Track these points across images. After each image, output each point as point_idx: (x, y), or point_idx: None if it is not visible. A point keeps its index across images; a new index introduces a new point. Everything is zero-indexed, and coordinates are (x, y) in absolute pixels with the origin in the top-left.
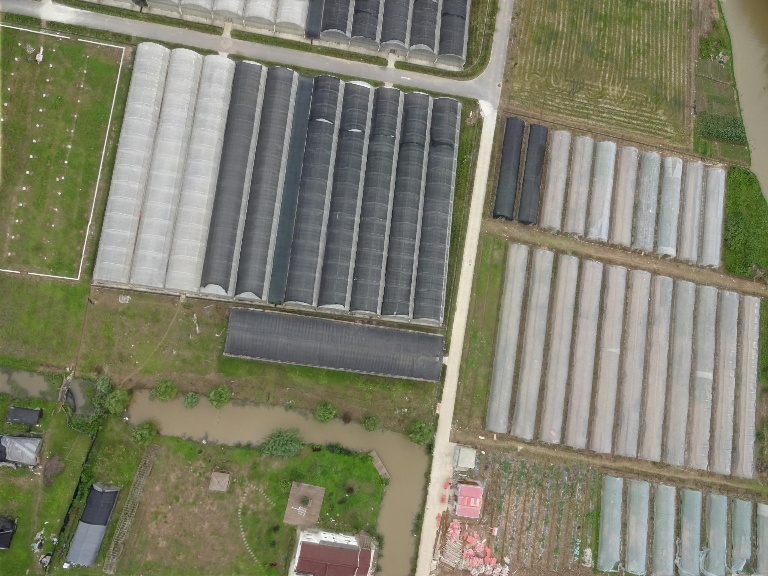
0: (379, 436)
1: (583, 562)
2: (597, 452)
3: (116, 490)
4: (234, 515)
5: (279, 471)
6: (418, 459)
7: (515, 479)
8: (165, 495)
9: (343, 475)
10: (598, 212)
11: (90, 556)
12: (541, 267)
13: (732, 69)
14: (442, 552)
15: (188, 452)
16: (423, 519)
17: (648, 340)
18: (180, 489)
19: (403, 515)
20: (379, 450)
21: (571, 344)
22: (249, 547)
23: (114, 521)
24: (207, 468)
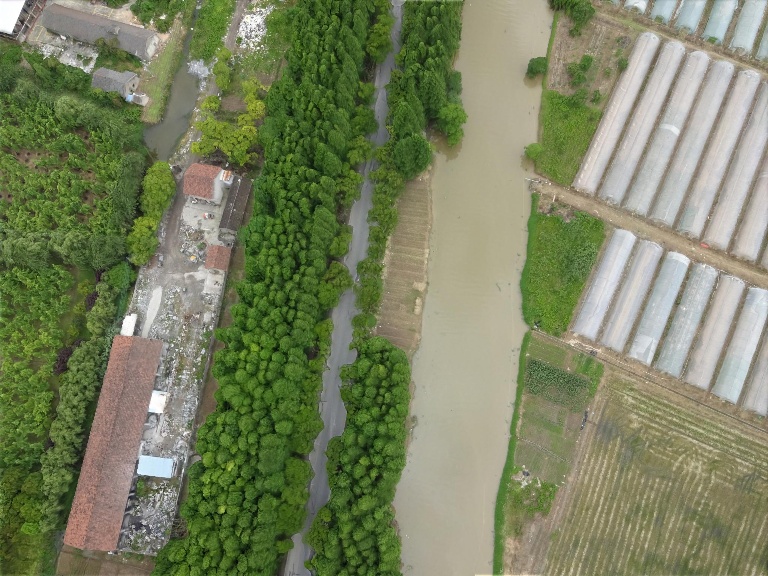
0: None
1: None
2: None
3: None
4: None
5: None
6: None
7: None
8: None
9: None
10: (762, 320)
11: None
12: None
13: (512, 461)
14: None
15: None
16: None
17: (722, 179)
18: None
19: None
20: None
21: None
22: None
23: None
24: None
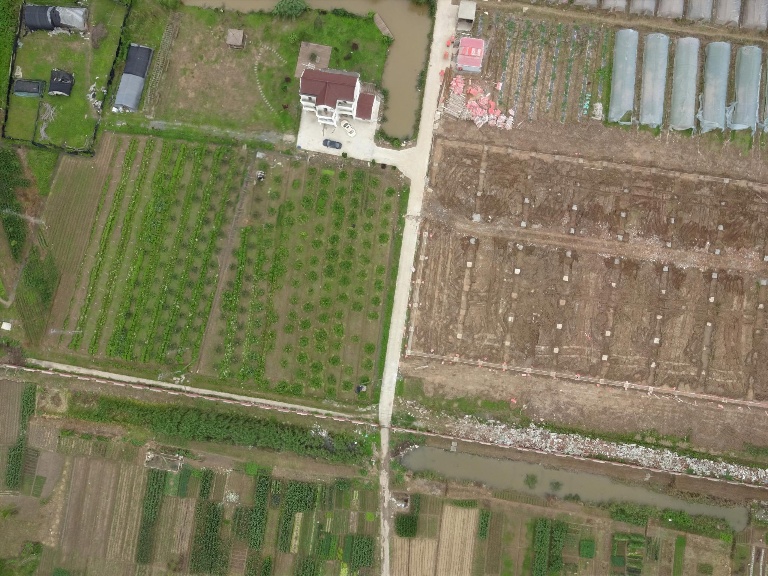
0: (382, 3)
1: (593, 115)
2: (610, 11)
3: (149, 48)
4: (251, 71)
5: (289, 33)
6: (421, 22)
7: (520, 37)
8: (191, 55)
9: (348, 36)
10: None
11: (132, 100)
12: None
13: None
14: (446, 104)
15: (208, 18)
16: (426, 75)
17: None
18: (203, 50)
19: (407, 72)
20: (382, 15)
21: None
22: (265, 98)
23: (150, 76)
24: (225, 32)
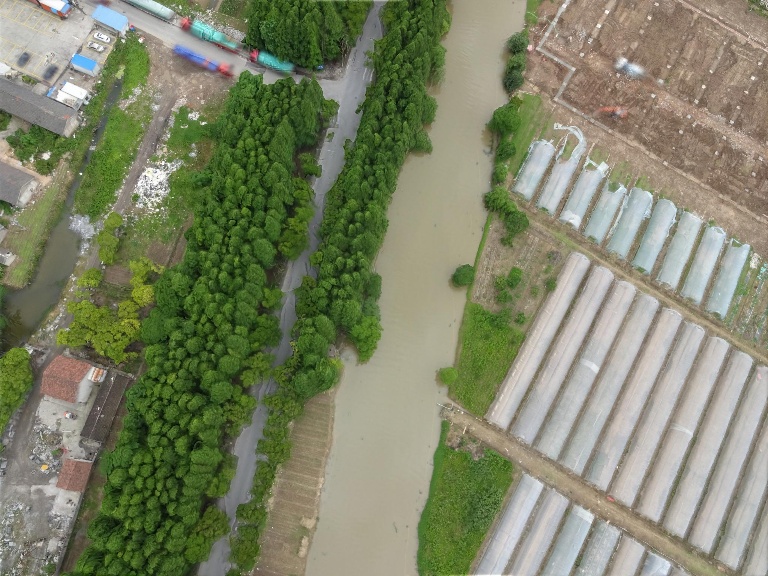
0: None
1: (760, 260)
2: None
3: None
4: None
5: None
6: None
7: None
8: None
9: None
10: None
11: None
12: (730, 548)
13: None
14: None
15: None
16: None
17: (635, 425)
18: None
19: None
20: None
21: (720, 454)
22: None
23: None
24: None
